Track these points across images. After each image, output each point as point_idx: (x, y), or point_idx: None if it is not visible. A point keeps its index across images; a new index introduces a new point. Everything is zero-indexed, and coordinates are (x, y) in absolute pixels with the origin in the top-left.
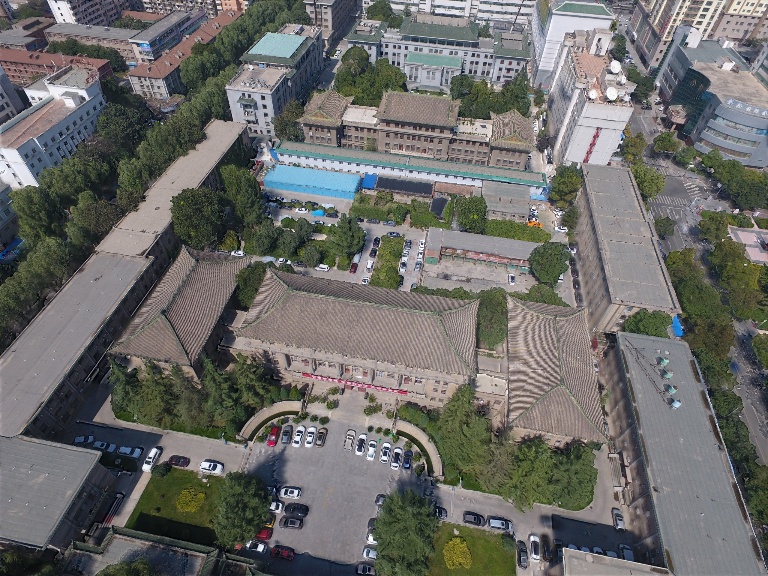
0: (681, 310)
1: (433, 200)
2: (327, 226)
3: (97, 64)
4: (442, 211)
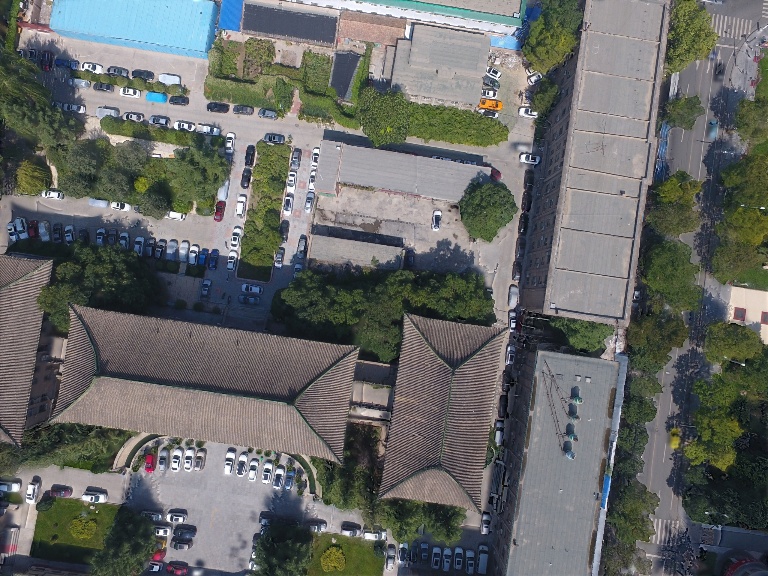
0: None
1: (336, 58)
2: (171, 133)
3: None
4: (348, 87)
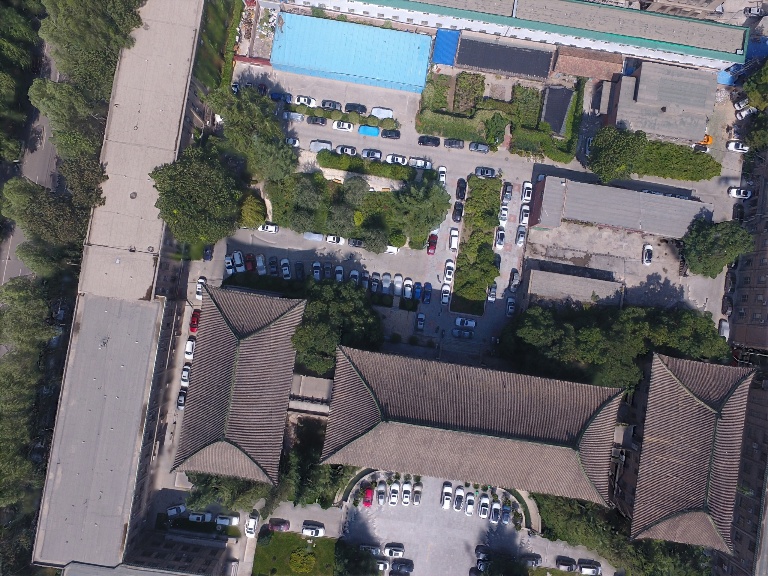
0: None
1: (549, 92)
2: (388, 167)
3: None
4: (563, 121)
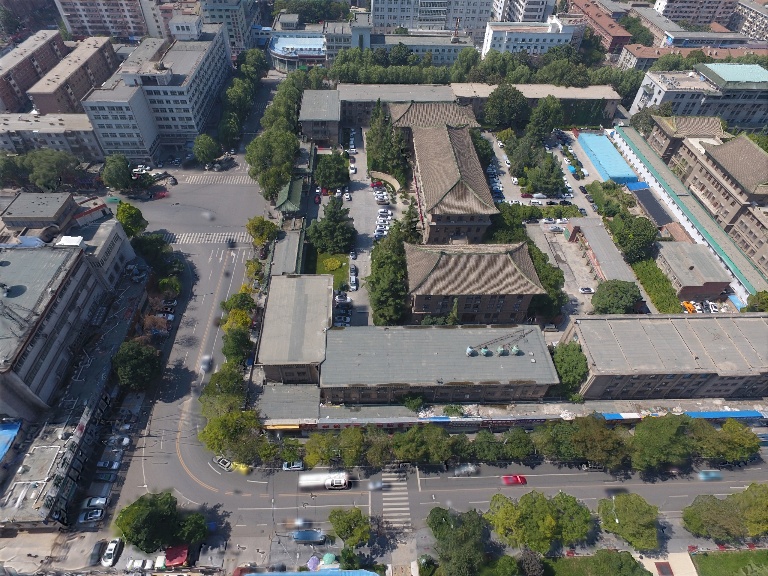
0: (599, 375)
1: None
2: None
3: (620, 33)
4: None
